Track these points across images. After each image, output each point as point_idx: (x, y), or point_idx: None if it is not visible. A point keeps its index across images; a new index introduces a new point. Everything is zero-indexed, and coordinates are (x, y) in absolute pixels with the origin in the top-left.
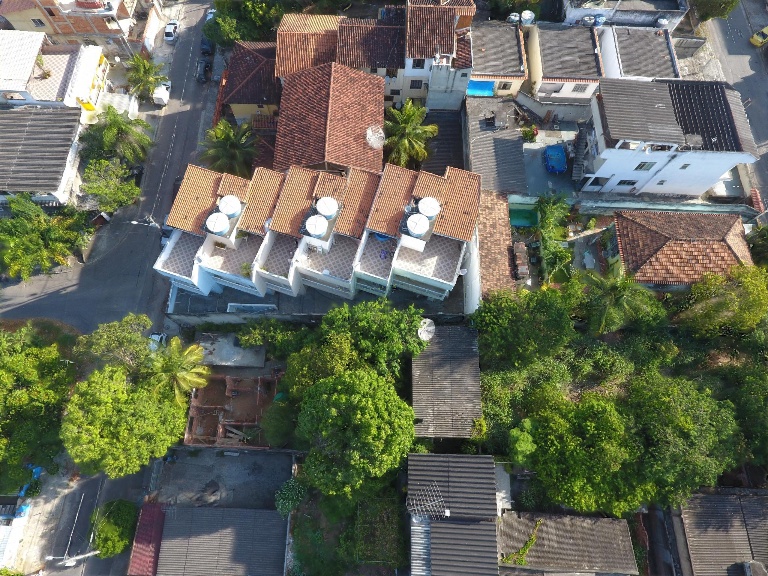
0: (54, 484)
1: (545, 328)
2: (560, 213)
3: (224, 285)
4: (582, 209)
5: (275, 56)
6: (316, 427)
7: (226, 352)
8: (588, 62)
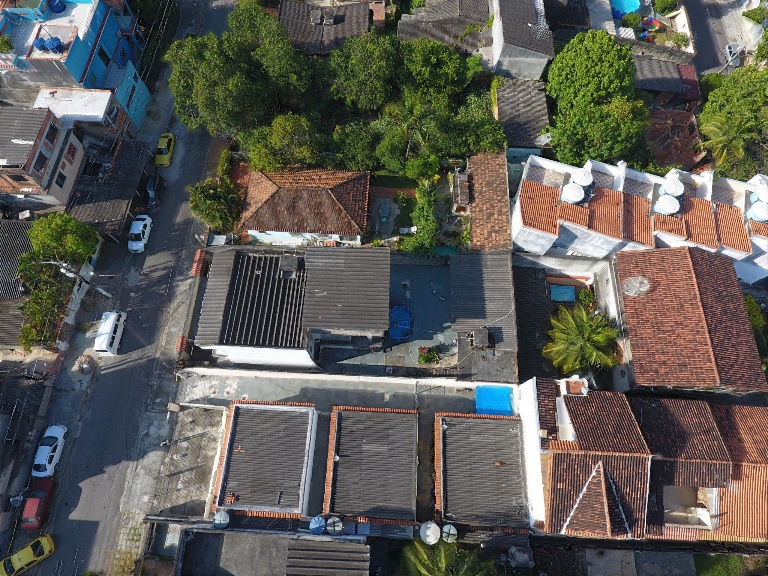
0: None
1: None
2: None
3: None
4: None
5: None
6: None
7: None
8: (351, 441)
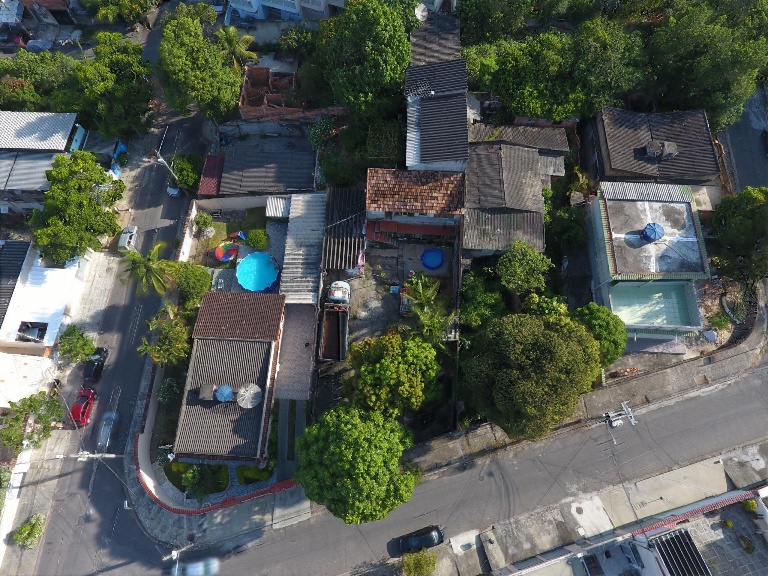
0: (136, 160)
1: (509, 4)
2: None
3: (268, 6)
4: None
5: None
6: (340, 45)
7: (268, 64)
8: None
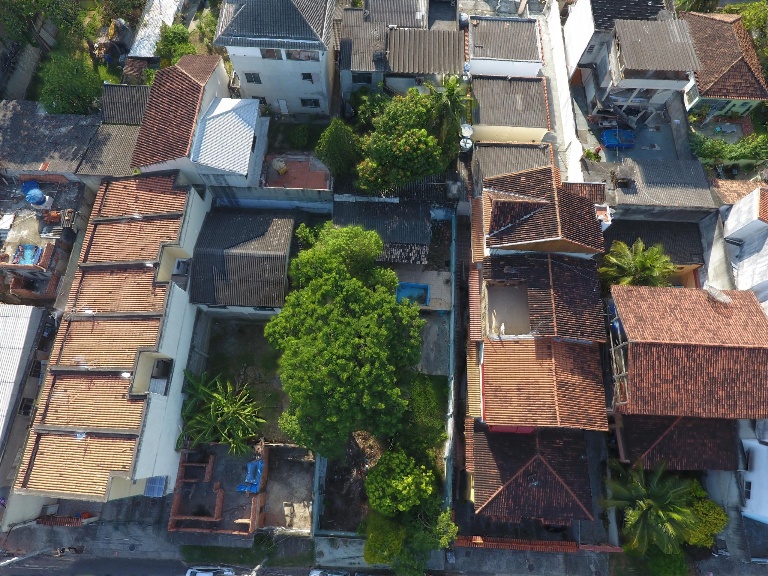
0: None
1: None
2: None
3: None
4: None
5: (525, 443)
6: None
7: None
8: (521, 87)
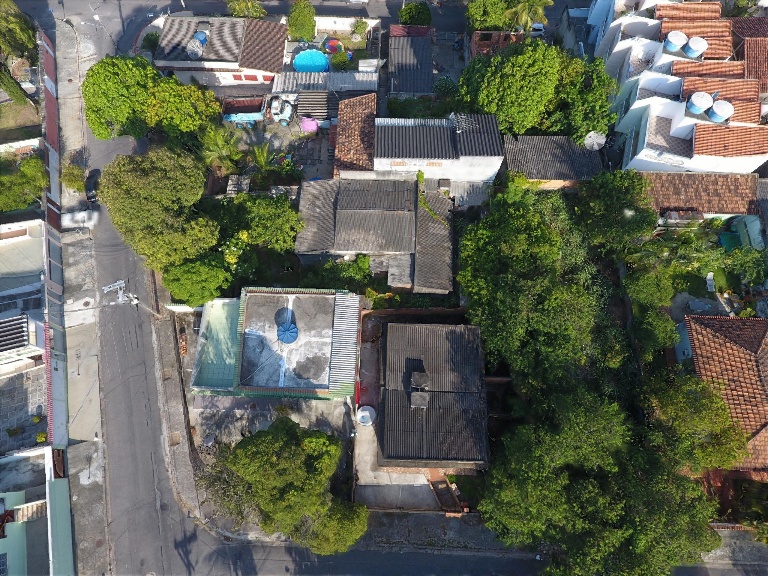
0: None
1: None
2: (751, 273)
3: None
4: (763, 305)
5: None
6: None
7: None
8: None
